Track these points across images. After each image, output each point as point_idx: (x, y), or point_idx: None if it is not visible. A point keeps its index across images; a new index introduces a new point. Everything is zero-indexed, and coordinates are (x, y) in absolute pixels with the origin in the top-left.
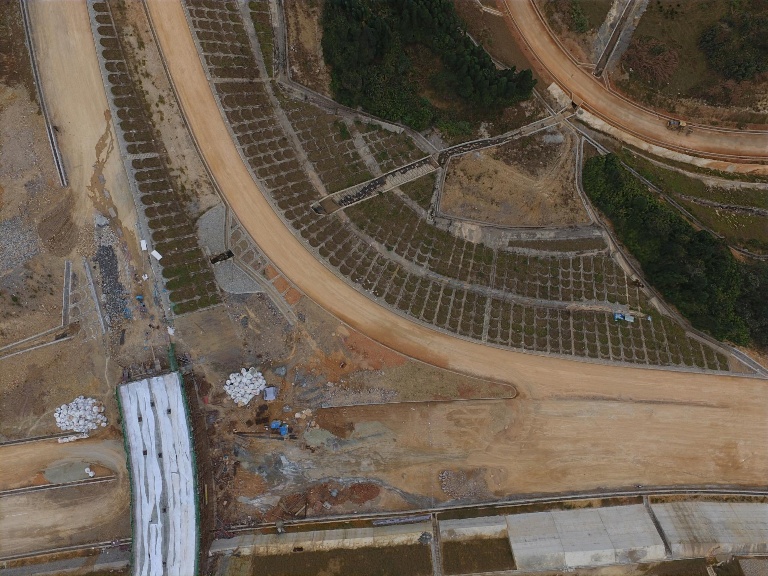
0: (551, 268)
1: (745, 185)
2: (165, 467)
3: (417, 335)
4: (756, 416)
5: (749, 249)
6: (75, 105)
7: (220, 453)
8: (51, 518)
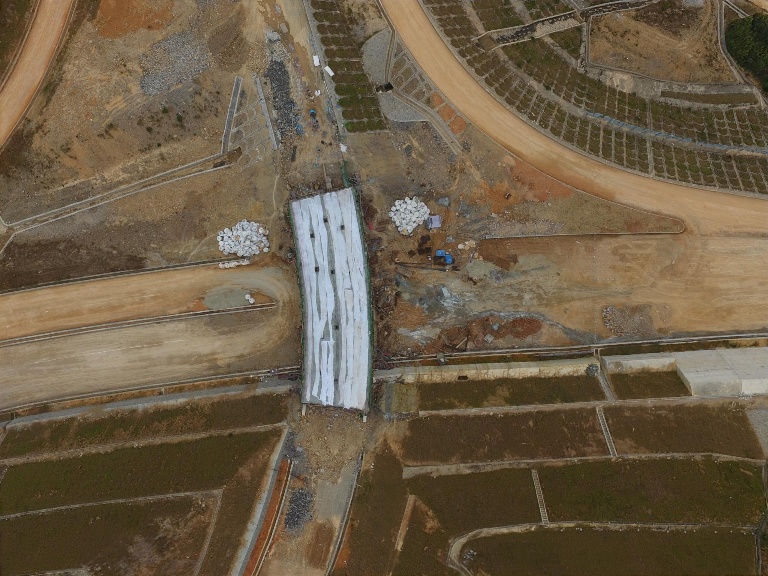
0: (705, 118)
1: None
2: (338, 283)
3: (583, 167)
4: None
5: None
6: None
7: (381, 283)
8: (209, 345)
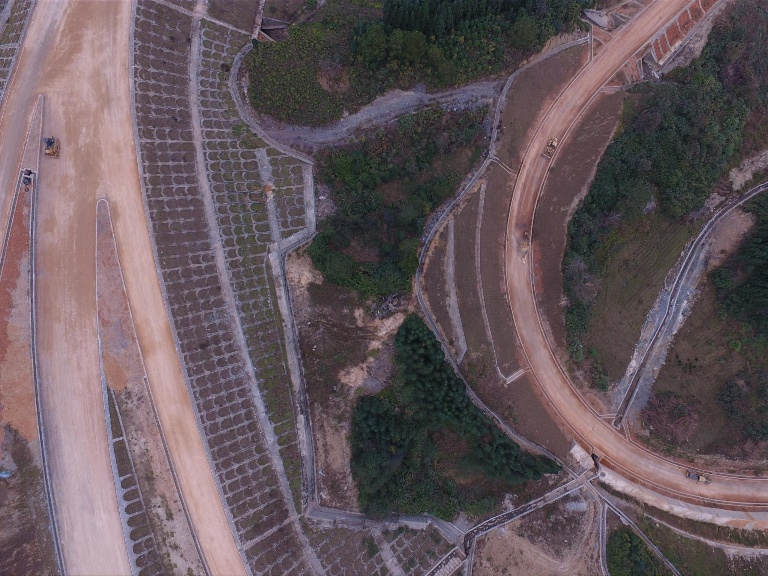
0: None
1: (765, 552)
2: None
3: None
4: None
5: None
6: None
7: None
8: None
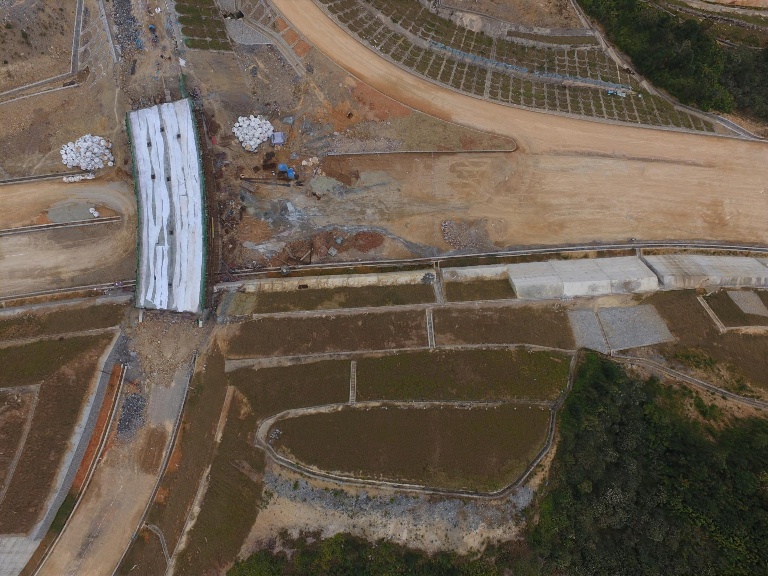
0: (547, 55)
1: (725, 9)
2: (173, 190)
3: (421, 90)
4: (740, 176)
5: (731, 40)
6: None
7: (227, 197)
8: (53, 259)
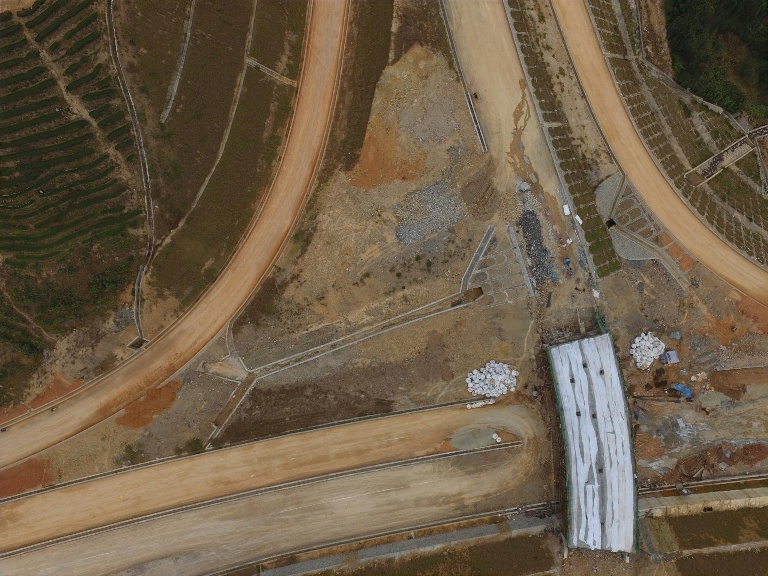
0: None
1: None
2: (600, 427)
3: None
4: None
5: None
6: (490, 74)
7: None
8: (457, 486)
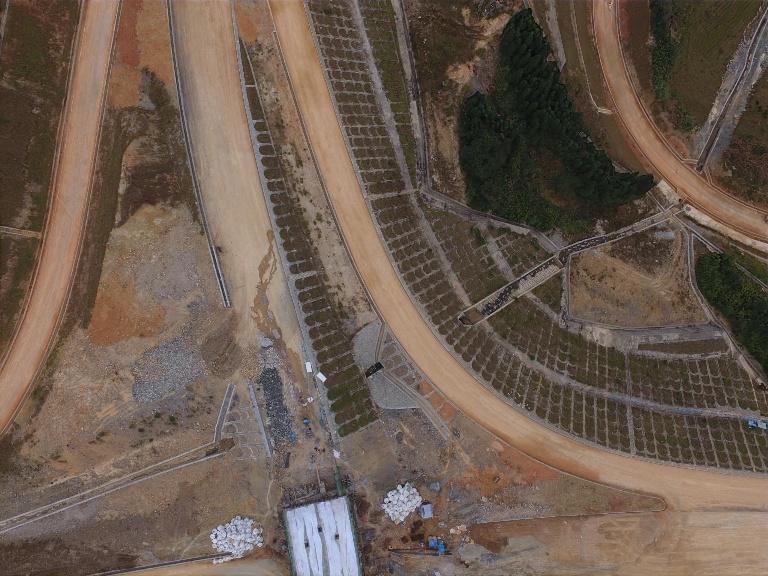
0: (680, 372)
1: None
2: None
3: (568, 449)
4: None
5: None
6: (237, 225)
7: (375, 570)
8: None
